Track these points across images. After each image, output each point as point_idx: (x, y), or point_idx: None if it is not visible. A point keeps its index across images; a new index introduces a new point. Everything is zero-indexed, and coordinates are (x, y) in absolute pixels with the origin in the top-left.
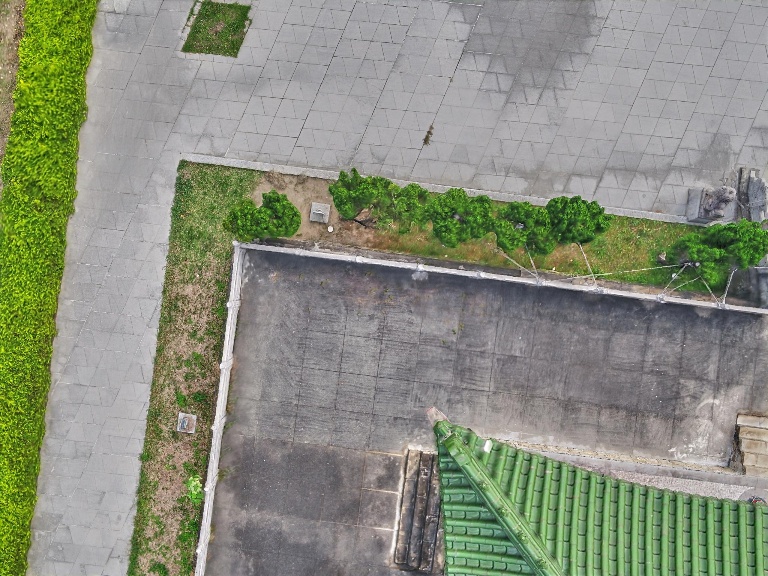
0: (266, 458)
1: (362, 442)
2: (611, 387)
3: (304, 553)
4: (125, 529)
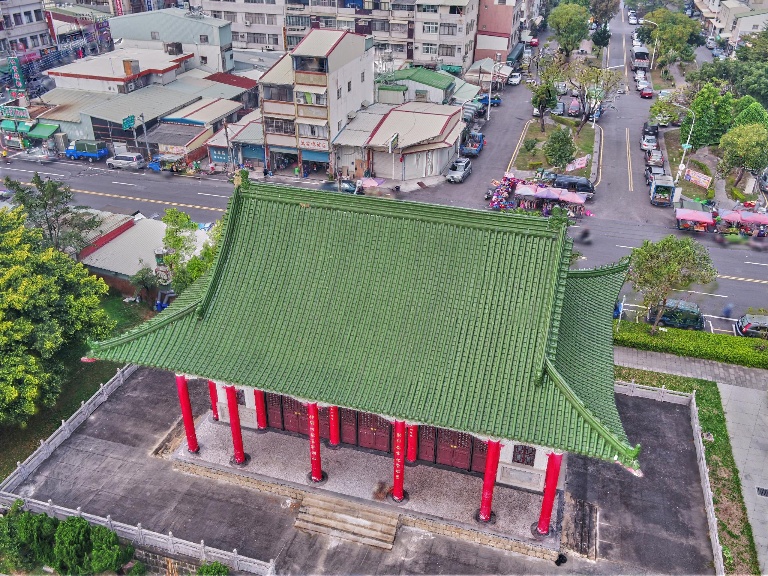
0: (685, 569)
1: (625, 569)
2: (468, 575)
3: (650, 519)
4: (763, 560)
